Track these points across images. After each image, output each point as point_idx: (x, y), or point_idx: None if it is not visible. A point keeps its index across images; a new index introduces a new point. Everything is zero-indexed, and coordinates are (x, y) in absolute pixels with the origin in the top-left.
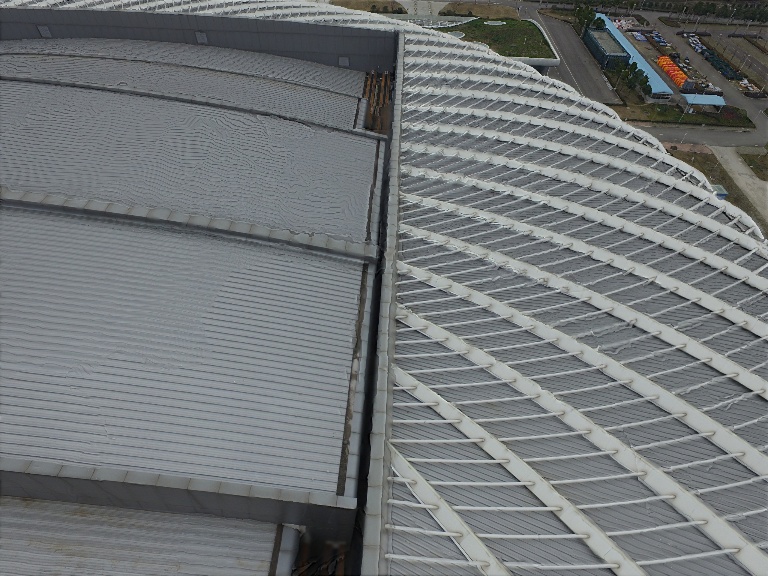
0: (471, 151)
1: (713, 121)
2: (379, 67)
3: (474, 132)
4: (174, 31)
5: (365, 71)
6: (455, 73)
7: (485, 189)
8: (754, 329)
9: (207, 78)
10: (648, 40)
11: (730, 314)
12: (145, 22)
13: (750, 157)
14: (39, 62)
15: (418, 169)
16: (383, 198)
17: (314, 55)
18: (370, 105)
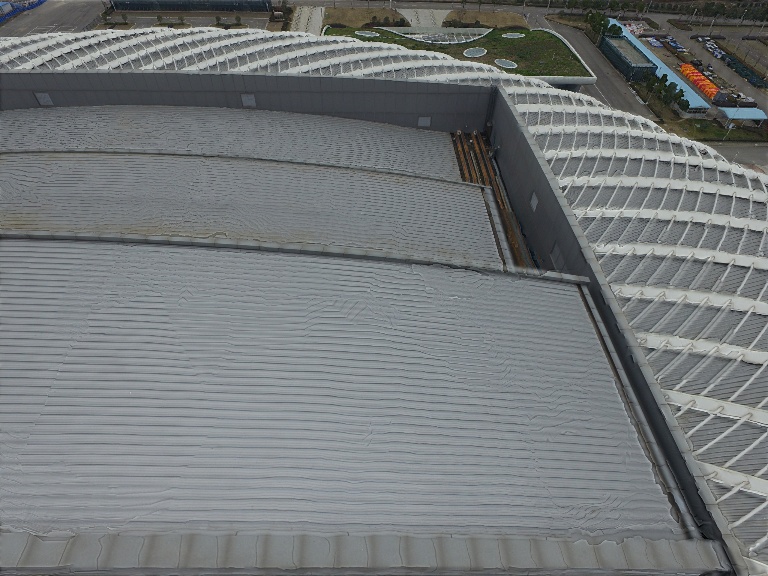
0: (702, 292)
1: (755, 136)
2: (467, 127)
3: (680, 252)
4: (214, 94)
5: (449, 131)
6: (597, 148)
7: (760, 365)
8: None
9: (291, 177)
10: (664, 46)
11: None
12: (177, 84)
13: None
14: (58, 165)
15: (655, 336)
16: (643, 406)
17: (389, 116)
18: (495, 195)
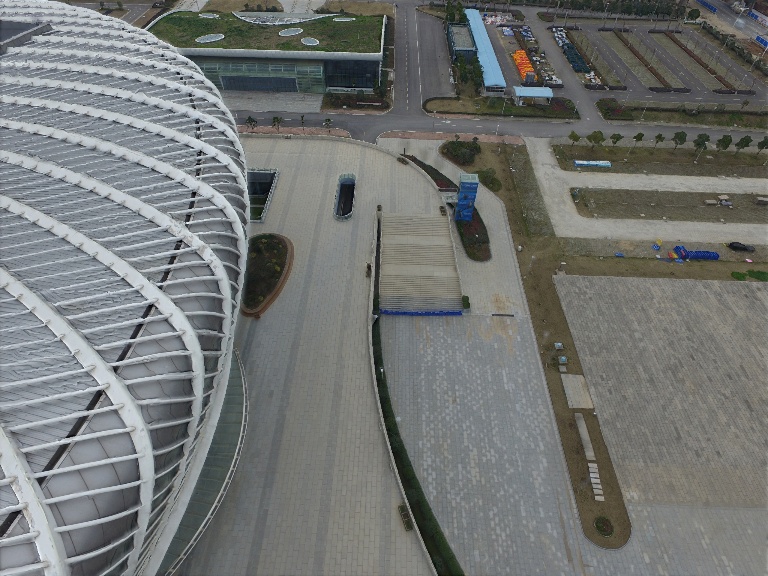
0: None
1: (540, 113)
2: None
3: None
4: None
5: None
6: (42, 62)
7: None
8: (24, 302)
9: None
10: (514, 35)
11: (13, 288)
12: None
13: (560, 147)
14: None
15: None
16: None
17: None
18: None
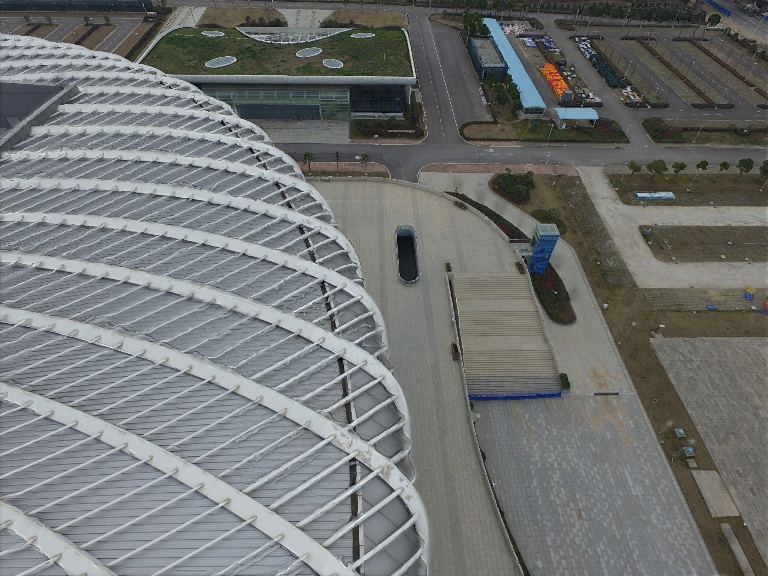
0: None
1: (586, 137)
2: None
3: (6, 258)
4: None
5: None
6: (84, 149)
7: None
8: None
9: None
10: (537, 46)
11: None
12: None
13: (617, 178)
14: None
15: None
16: None
17: None
18: None
